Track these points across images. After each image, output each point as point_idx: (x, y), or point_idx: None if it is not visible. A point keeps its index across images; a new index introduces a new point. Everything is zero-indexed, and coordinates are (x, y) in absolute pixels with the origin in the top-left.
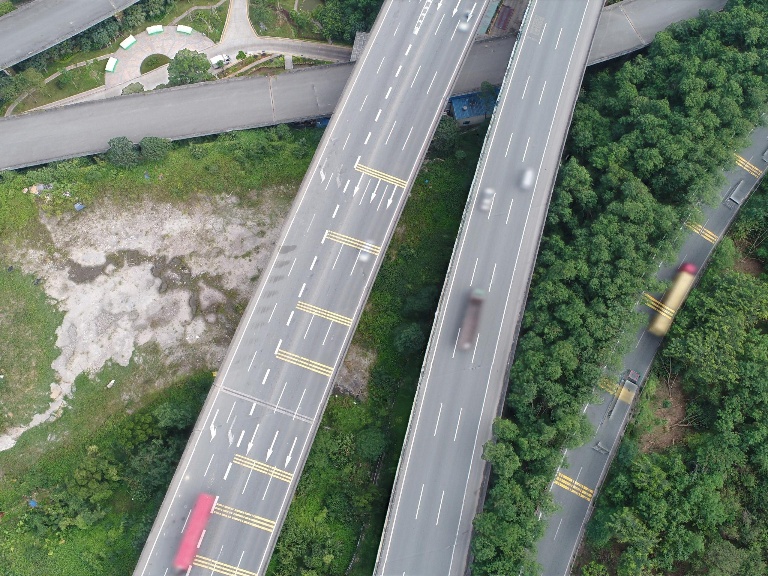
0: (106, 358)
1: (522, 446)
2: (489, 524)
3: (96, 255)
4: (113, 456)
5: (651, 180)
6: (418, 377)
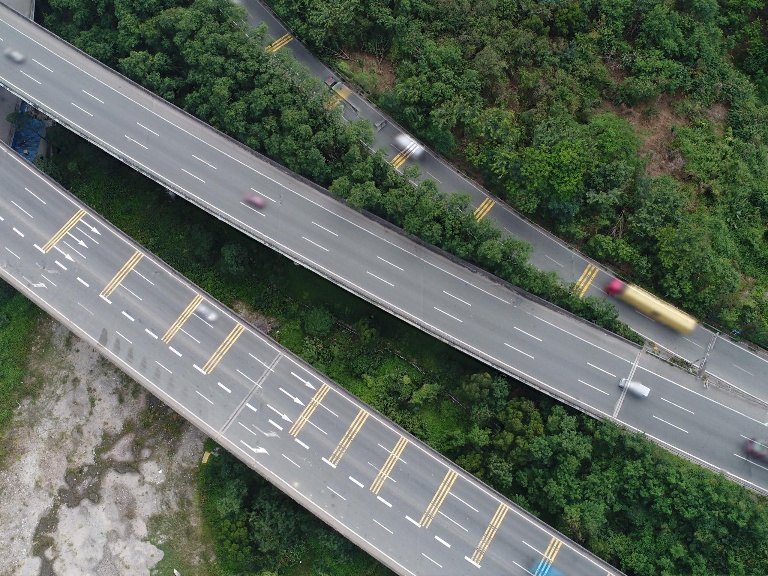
0: (148, 575)
1: (359, 176)
2: (414, 220)
3: (28, 568)
4: (252, 574)
5: (166, 8)
6: (273, 267)
